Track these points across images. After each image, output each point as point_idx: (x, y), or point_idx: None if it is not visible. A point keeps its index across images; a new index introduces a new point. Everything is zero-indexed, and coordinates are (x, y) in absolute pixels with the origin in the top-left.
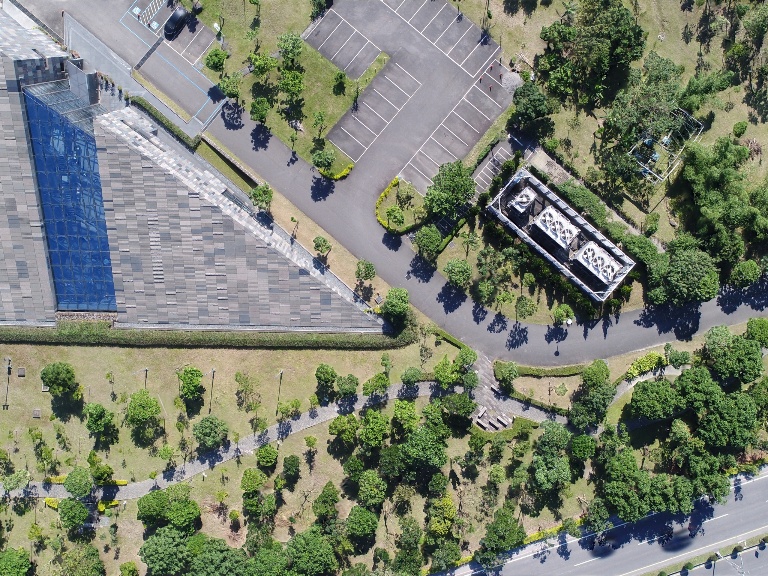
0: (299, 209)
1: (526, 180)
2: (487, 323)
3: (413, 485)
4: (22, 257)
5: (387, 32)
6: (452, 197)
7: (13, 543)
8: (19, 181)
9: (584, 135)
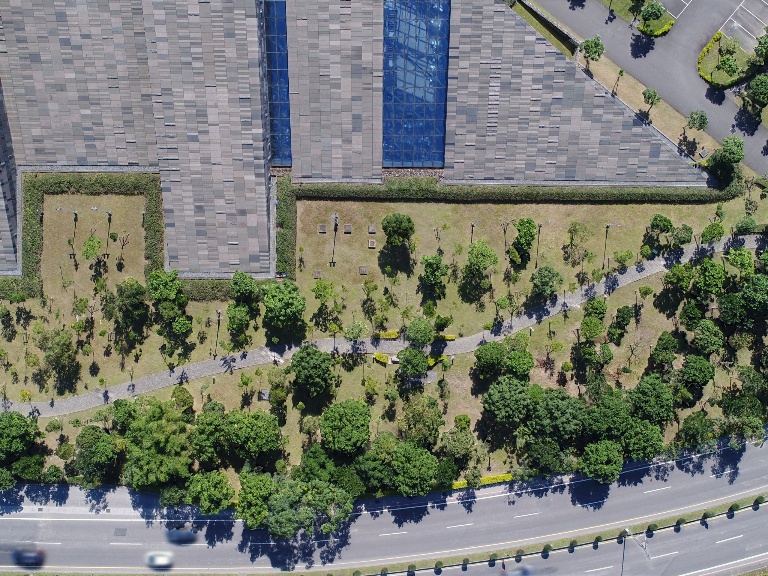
0: (618, 66)
1: None
2: None
3: (748, 334)
4: (359, 109)
5: None
6: None
7: (341, 399)
8: (369, 28)
9: None
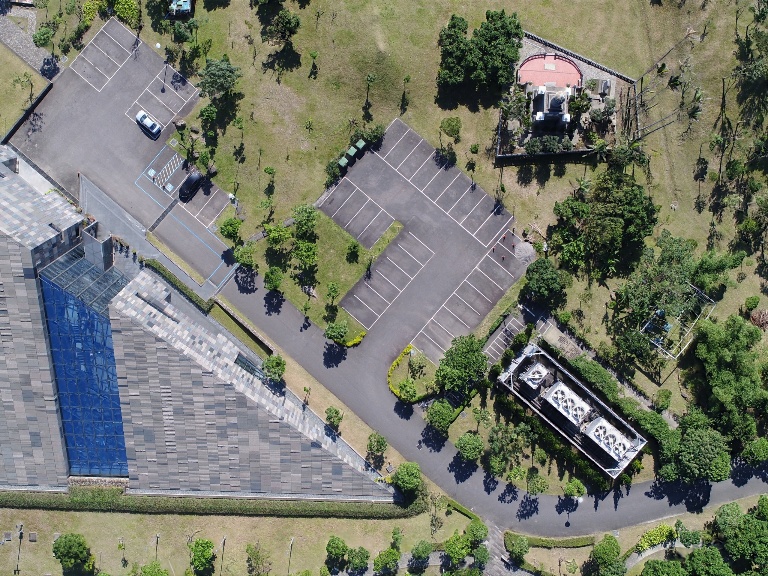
0: (311, 375)
1: (538, 351)
2: (498, 493)
3: None
4: (35, 428)
5: (401, 201)
6: (464, 375)
7: None
8: (34, 359)
9: (596, 305)
